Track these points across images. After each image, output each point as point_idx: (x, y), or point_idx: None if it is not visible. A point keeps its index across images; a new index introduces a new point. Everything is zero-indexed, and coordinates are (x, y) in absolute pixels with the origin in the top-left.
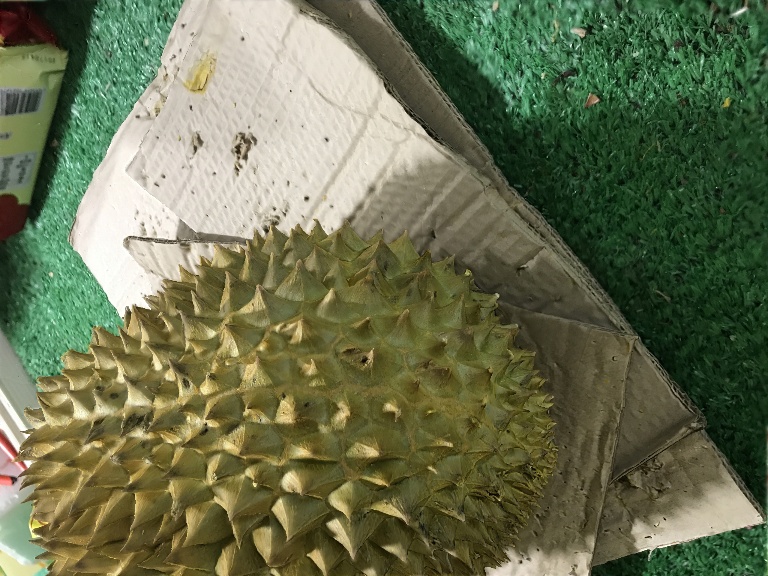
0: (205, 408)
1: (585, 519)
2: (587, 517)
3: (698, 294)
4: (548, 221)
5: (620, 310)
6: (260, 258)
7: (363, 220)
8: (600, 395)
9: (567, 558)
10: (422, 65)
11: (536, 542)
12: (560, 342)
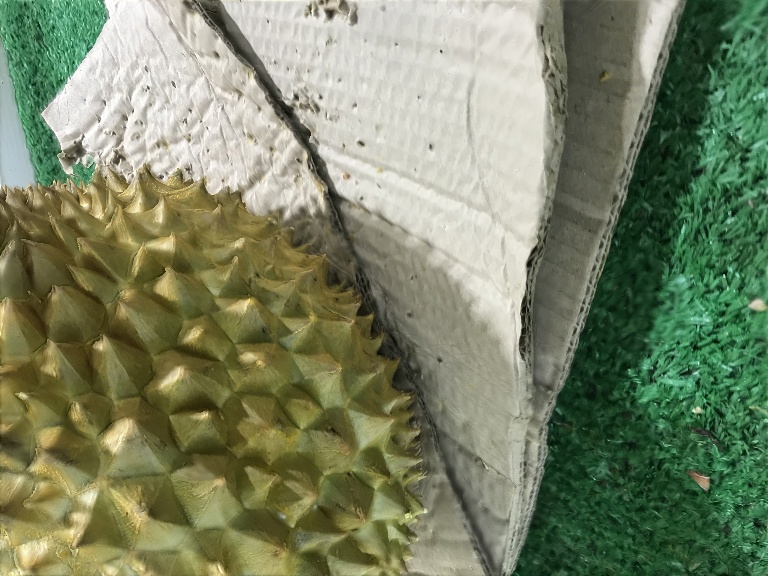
0: (9, 573)
1: None
2: None
3: None
4: (547, 460)
5: (523, 546)
6: (205, 346)
7: (395, 246)
8: (441, 574)
9: None
10: (609, 238)
11: None
12: (449, 534)
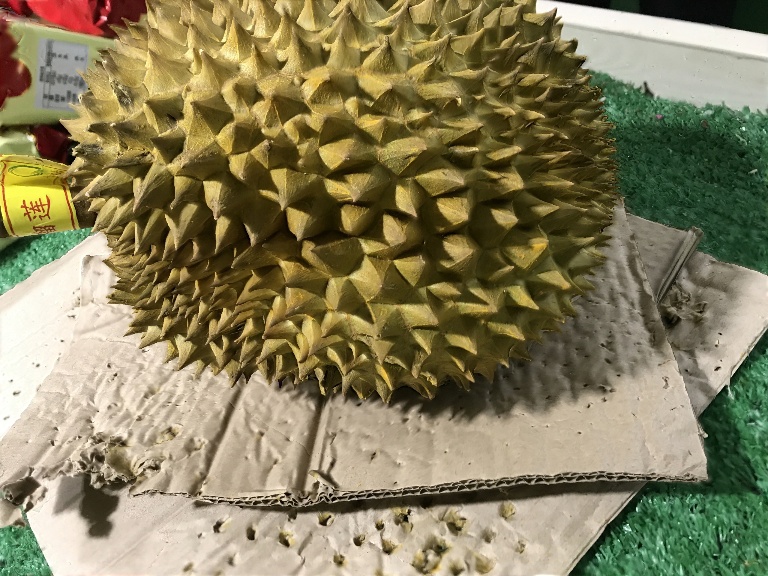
0: None
1: (651, 333)
2: (652, 331)
3: (648, 199)
4: None
5: None
6: None
7: None
8: (615, 234)
9: (653, 372)
10: None
11: (613, 369)
12: None
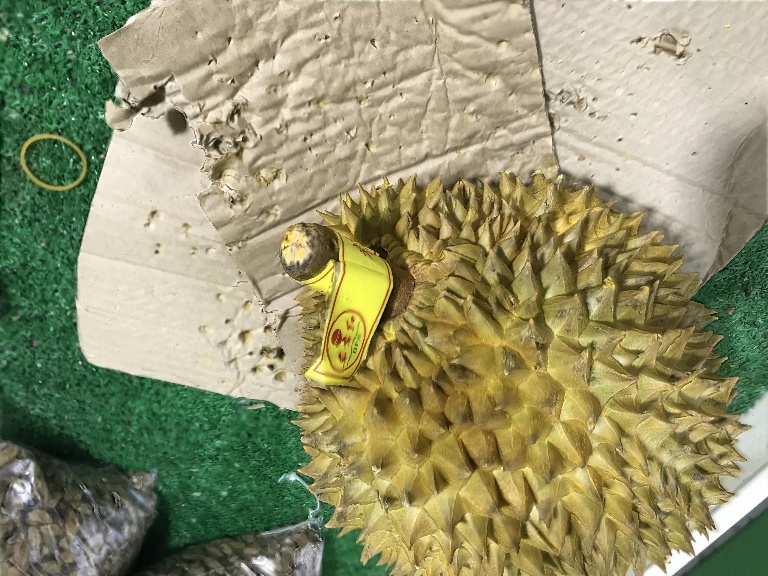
0: None
1: None
2: None
3: None
4: None
5: None
6: None
7: None
8: None
9: None
10: None
11: None
12: None
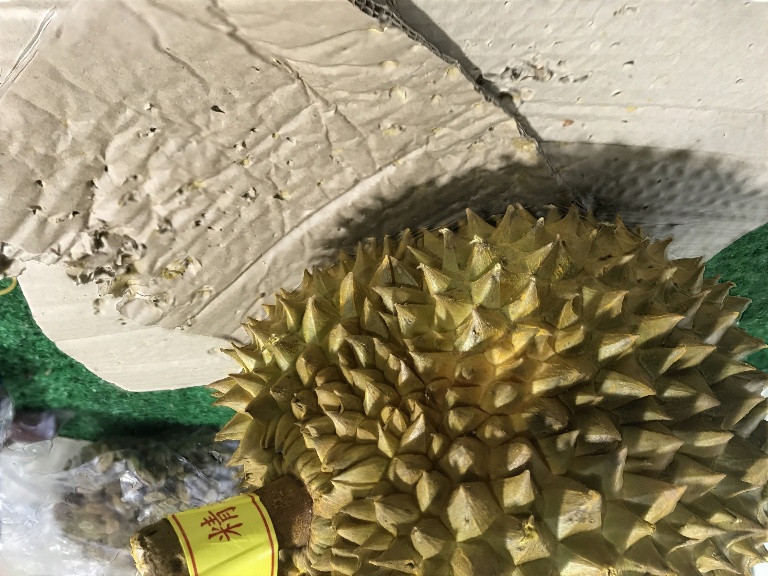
0: None
1: None
2: None
3: None
4: None
5: None
6: None
7: (638, 164)
8: None
9: None
10: None
11: None
12: None
